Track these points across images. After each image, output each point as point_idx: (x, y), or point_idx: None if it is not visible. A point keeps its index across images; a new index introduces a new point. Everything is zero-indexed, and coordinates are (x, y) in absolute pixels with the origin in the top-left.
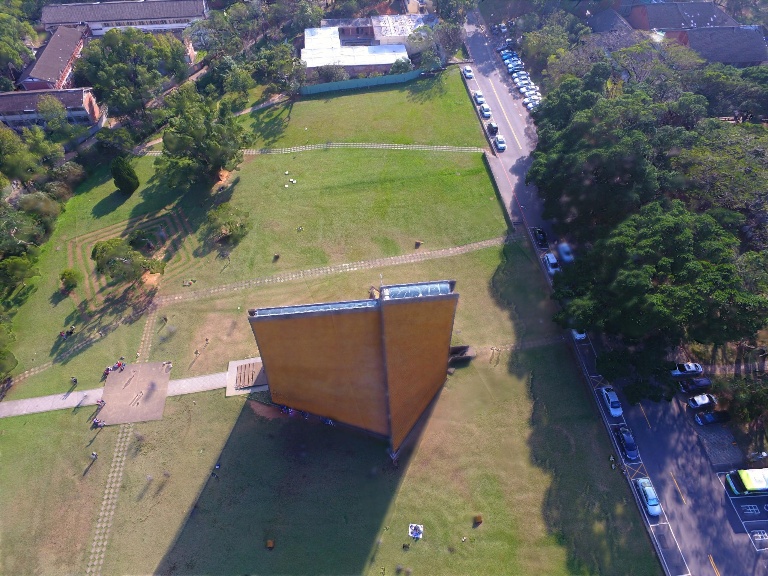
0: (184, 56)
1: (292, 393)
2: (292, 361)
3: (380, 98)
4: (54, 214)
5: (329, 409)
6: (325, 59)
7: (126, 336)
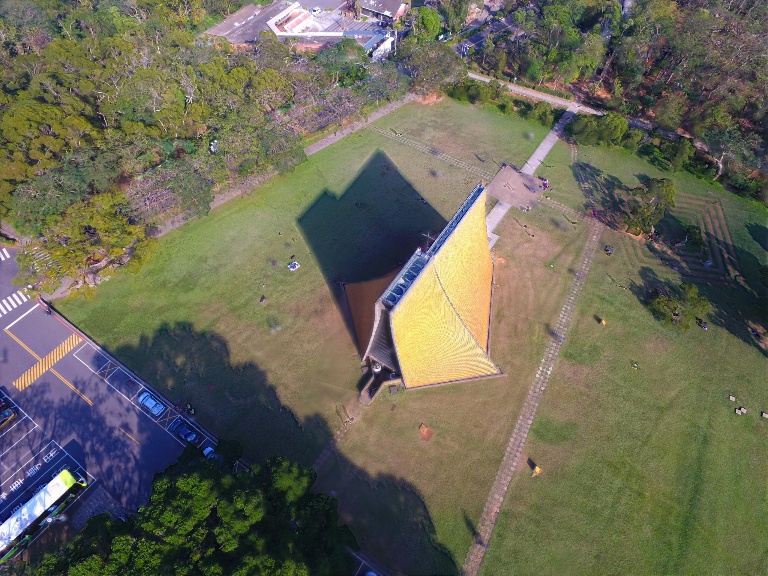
0: None
1: None
2: None
3: None
4: None
5: None
6: None
7: (573, 198)
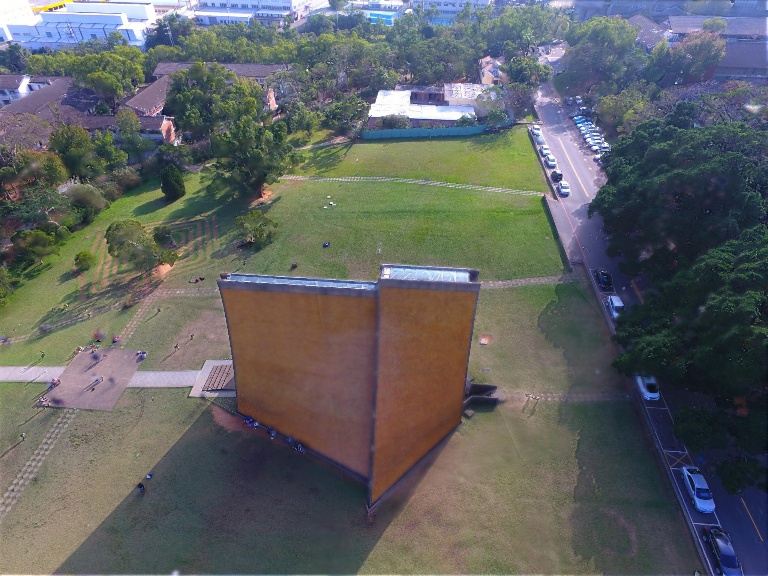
0: (265, 106)
1: (261, 401)
2: (266, 355)
3: (440, 146)
4: (98, 208)
5: (301, 429)
6: None
7: (113, 320)
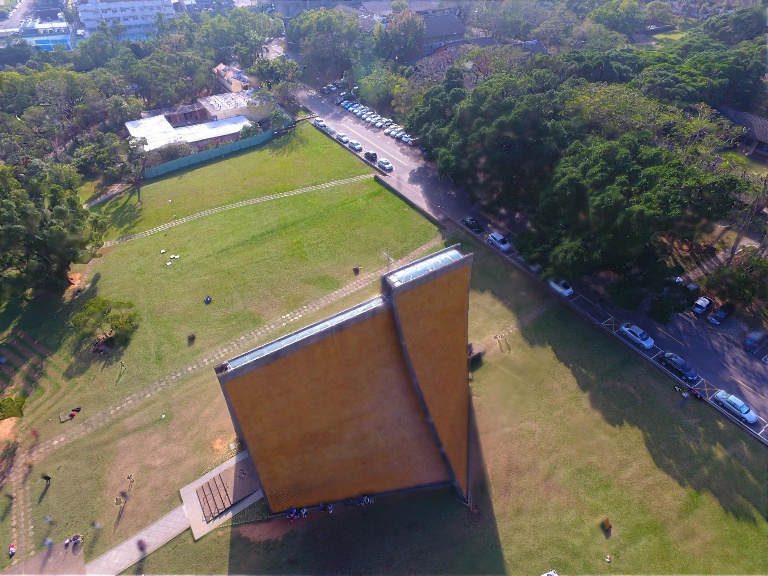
0: None
1: (300, 483)
2: (290, 430)
3: (241, 161)
4: None
5: (358, 482)
6: (162, 141)
7: None
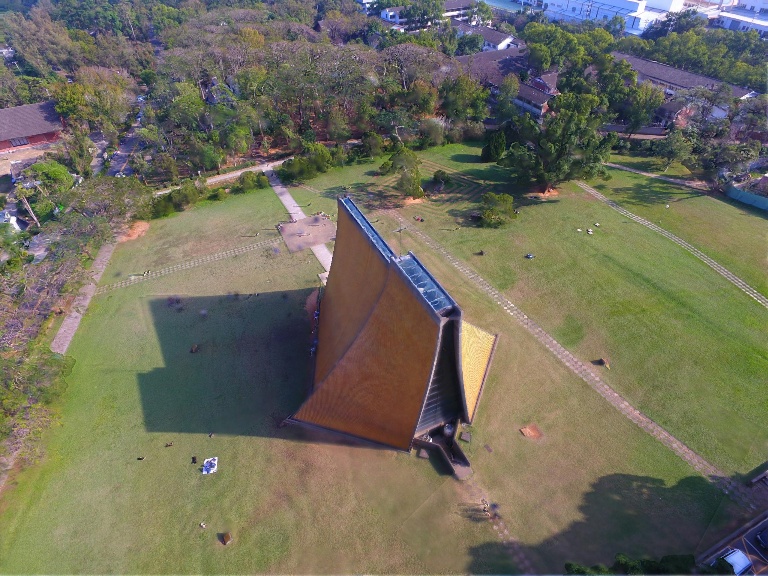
0: (670, 122)
1: (326, 304)
2: (340, 272)
3: None
4: (436, 143)
5: (323, 340)
6: None
7: None
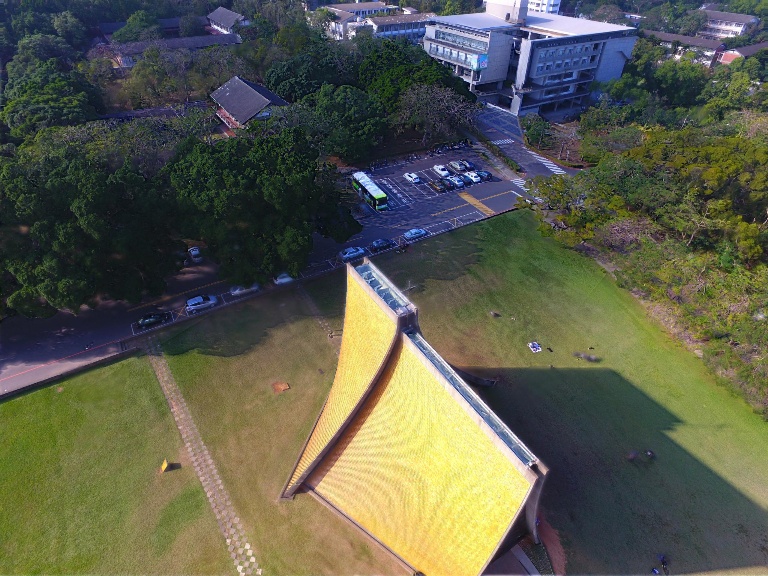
0: None
1: None
2: None
3: None
4: None
5: None
6: None
7: None
